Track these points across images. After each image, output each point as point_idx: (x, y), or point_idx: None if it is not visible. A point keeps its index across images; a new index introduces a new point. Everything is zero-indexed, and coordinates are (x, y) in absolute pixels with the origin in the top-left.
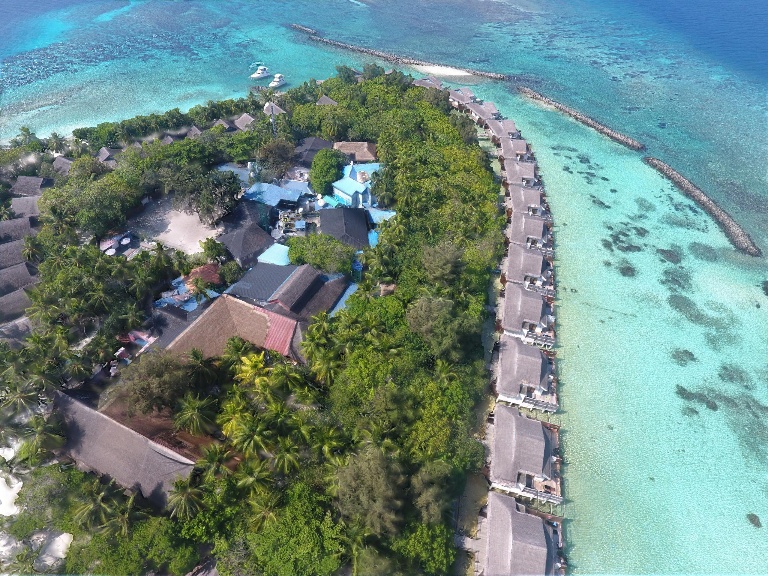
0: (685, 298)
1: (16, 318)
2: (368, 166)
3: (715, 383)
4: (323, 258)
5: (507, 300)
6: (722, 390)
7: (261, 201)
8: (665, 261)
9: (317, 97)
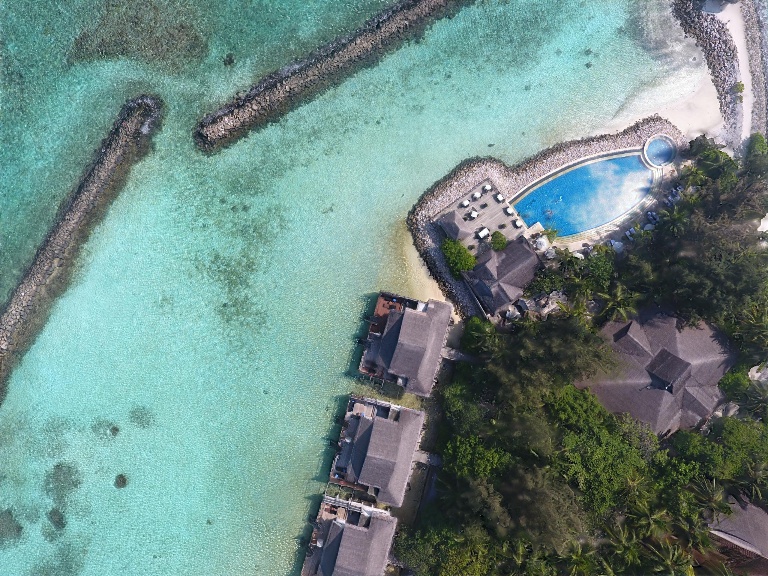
0: None
1: None
2: None
3: None
4: None
5: None
6: None
7: None
8: None
9: None
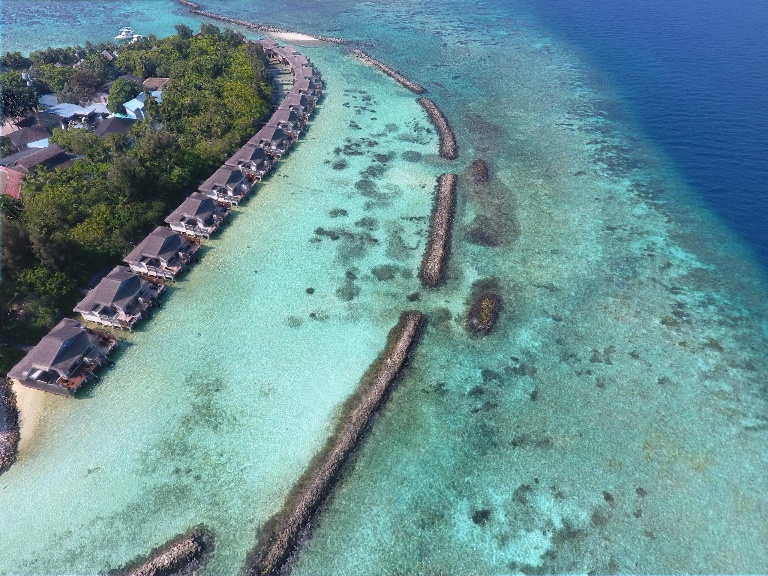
0: (370, 182)
1: None
2: (158, 93)
3: (348, 227)
4: (71, 141)
5: (213, 174)
6: (350, 230)
7: (57, 114)
8: (375, 161)
9: None
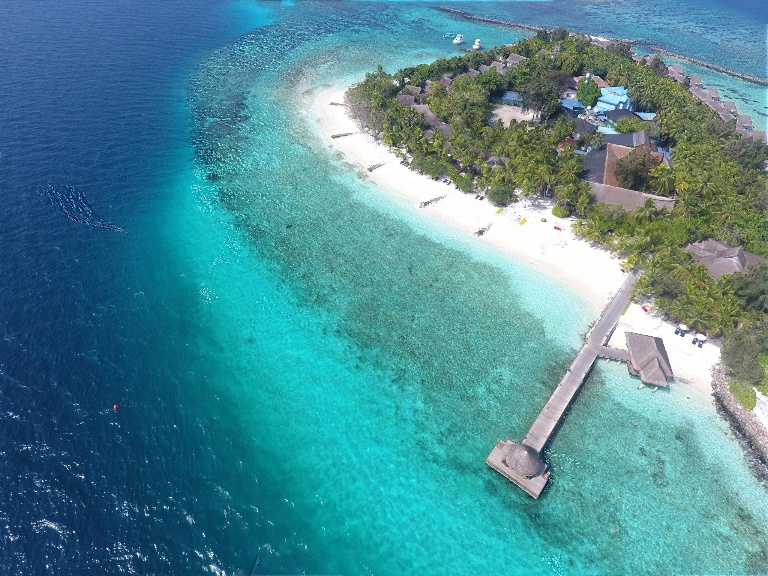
0: None
1: (486, 160)
2: (615, 88)
3: None
4: None
5: None
6: None
7: None
8: None
9: (531, 52)
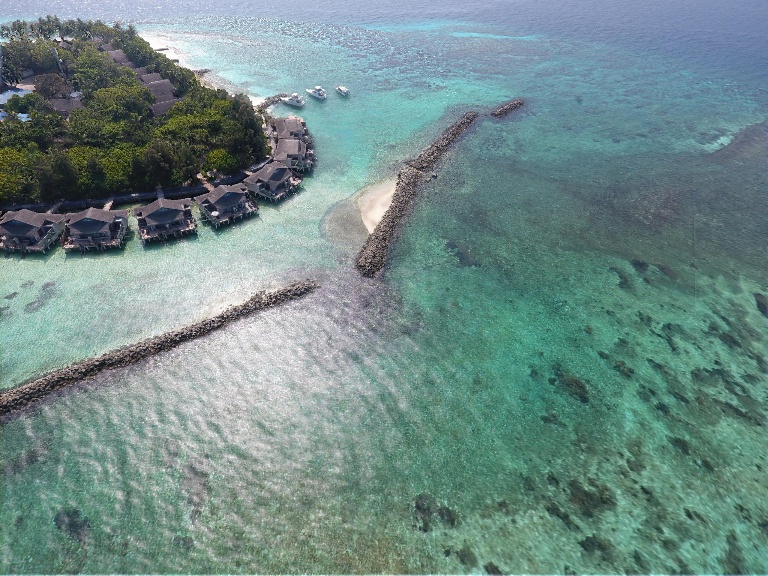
0: None
1: None
2: None
3: None
4: None
5: None
6: None
7: (4, 93)
8: None
9: None
